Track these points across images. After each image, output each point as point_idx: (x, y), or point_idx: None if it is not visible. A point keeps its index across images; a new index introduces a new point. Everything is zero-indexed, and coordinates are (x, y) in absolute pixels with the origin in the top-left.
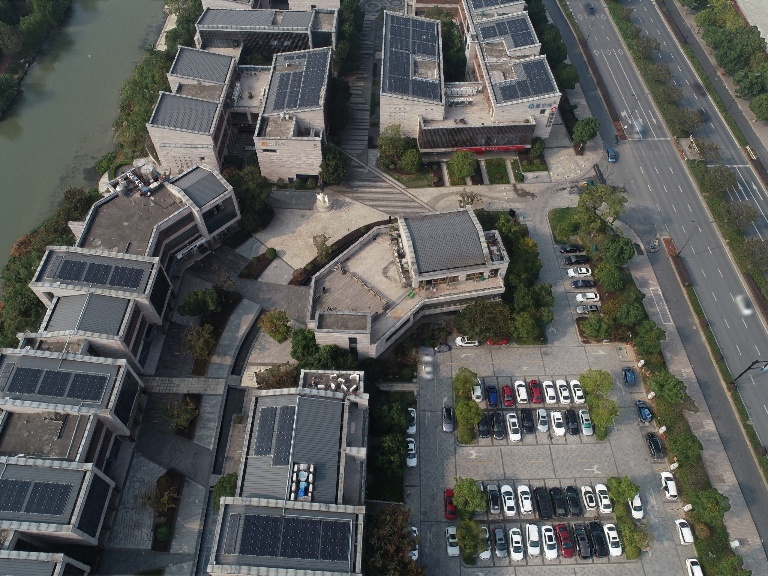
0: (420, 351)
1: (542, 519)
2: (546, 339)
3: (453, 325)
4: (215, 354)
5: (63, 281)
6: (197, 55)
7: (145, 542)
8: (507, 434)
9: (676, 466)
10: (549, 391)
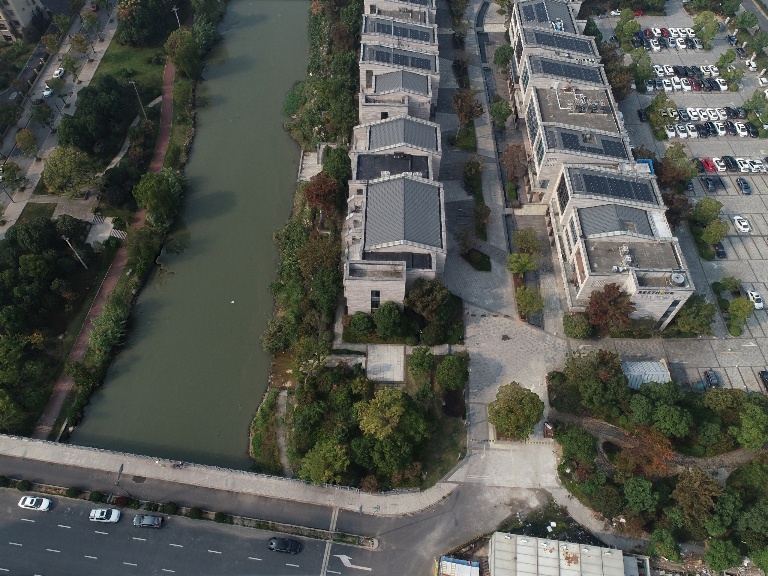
0: (590, 17)
1: (680, 77)
2: (666, 14)
3: (609, 2)
4: None
5: None
6: None
7: (455, 86)
8: (651, 49)
9: (755, 55)
10: (674, 30)
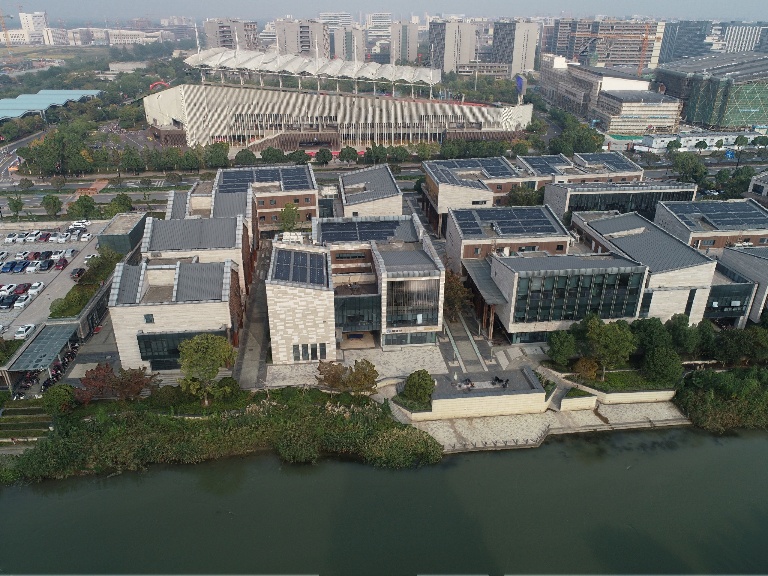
0: None
1: None
2: None
3: None
4: None
5: None
6: (765, 257)
7: None
8: None
9: None
10: None
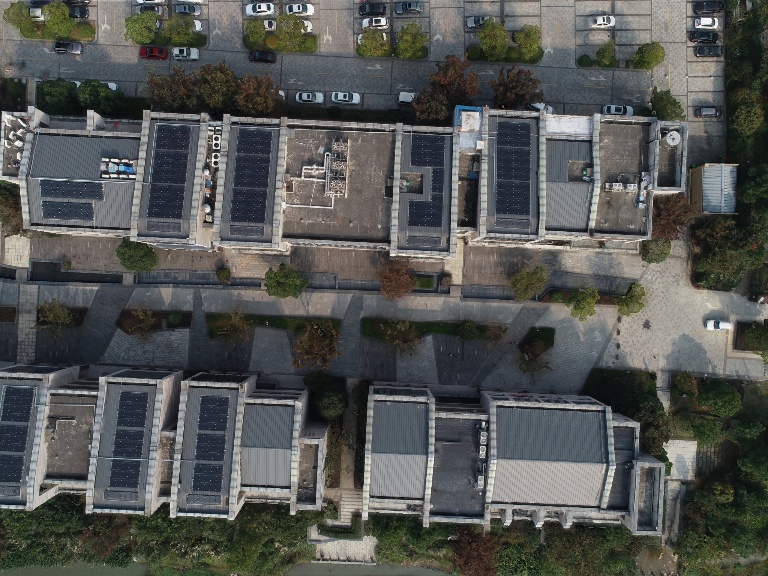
0: None
1: None
2: None
3: None
4: None
5: None
6: None
7: (183, 335)
8: None
9: None
10: None
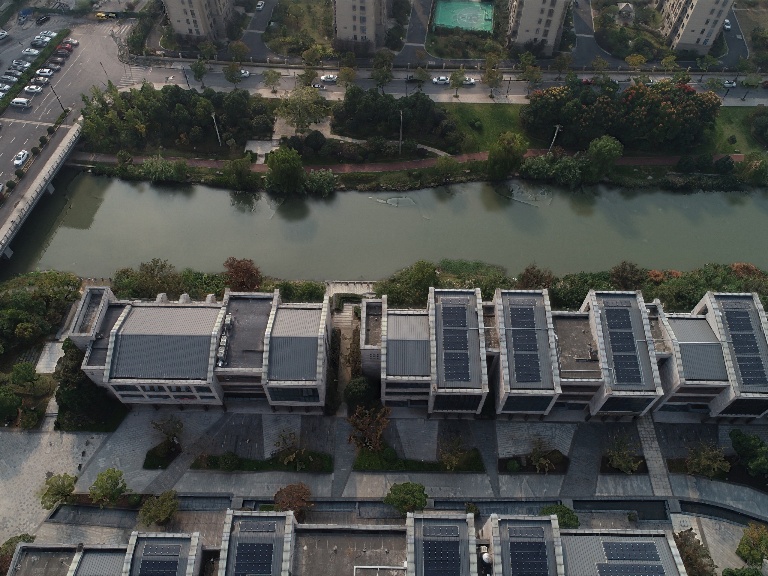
0: None
1: None
2: None
3: None
4: (697, 479)
5: (724, 317)
6: None
7: (504, 452)
8: None
9: None
10: None
